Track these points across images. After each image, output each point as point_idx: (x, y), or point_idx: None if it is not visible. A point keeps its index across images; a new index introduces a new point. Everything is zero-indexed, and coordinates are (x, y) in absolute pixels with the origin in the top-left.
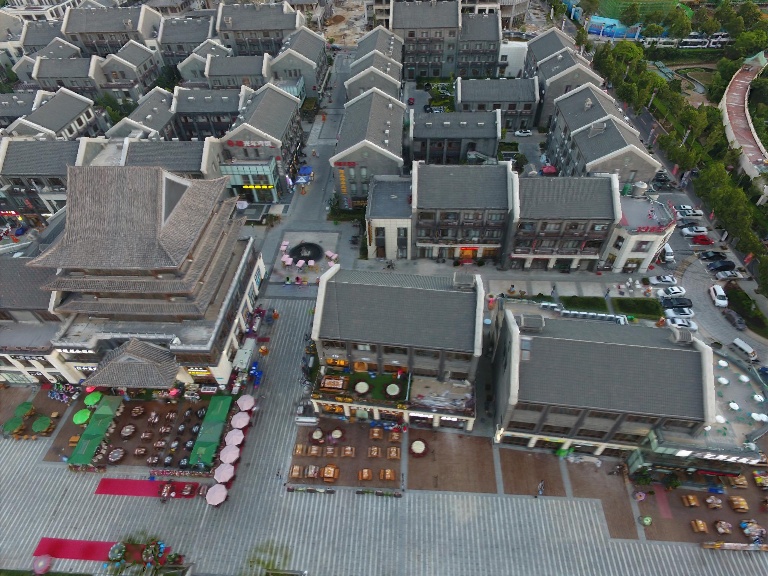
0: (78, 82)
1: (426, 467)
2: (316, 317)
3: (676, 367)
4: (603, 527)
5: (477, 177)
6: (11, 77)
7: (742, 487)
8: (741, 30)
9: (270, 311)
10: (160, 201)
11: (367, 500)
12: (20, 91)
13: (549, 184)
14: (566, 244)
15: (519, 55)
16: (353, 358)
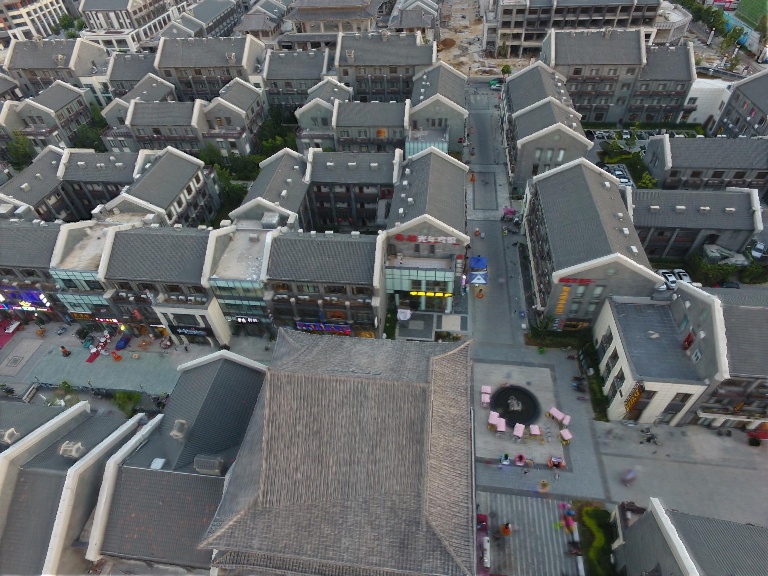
0: (178, 131)
1: None
2: None
3: None
4: None
5: None
6: (96, 118)
7: None
8: None
9: (493, 518)
10: (427, 442)
11: None
12: (109, 139)
13: None
14: None
15: (713, 98)
16: None
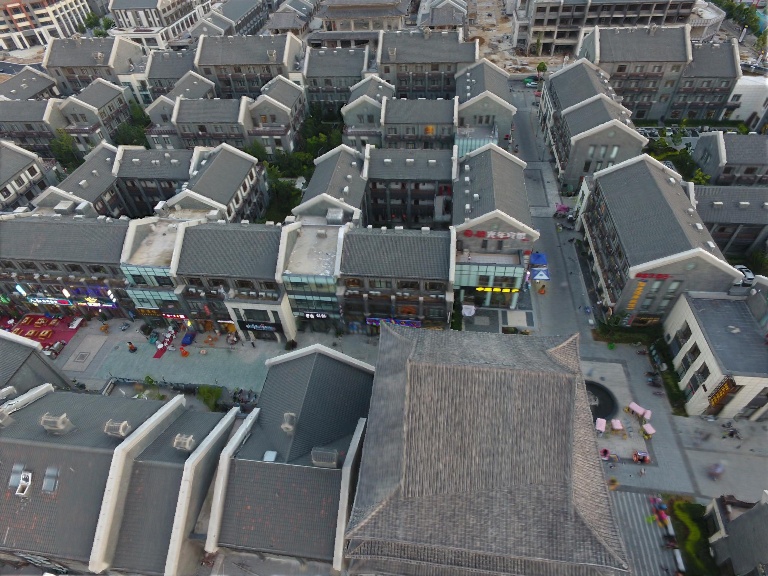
0: (223, 128)
1: None
2: None
3: None
4: None
5: None
6: (136, 116)
7: None
8: None
9: None
10: (573, 433)
11: None
12: (153, 136)
13: None
14: None
15: (758, 95)
16: None
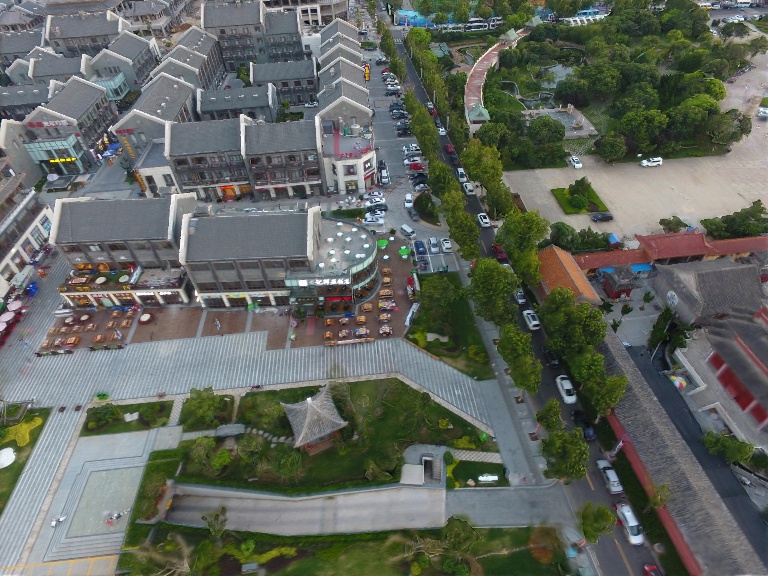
0: None
1: (148, 329)
2: (52, 228)
3: (292, 225)
4: (263, 345)
5: (218, 128)
6: None
7: (368, 310)
8: (508, 13)
9: None
10: None
11: (97, 354)
12: None
13: (269, 128)
14: (294, 174)
15: (319, 44)
16: (92, 259)
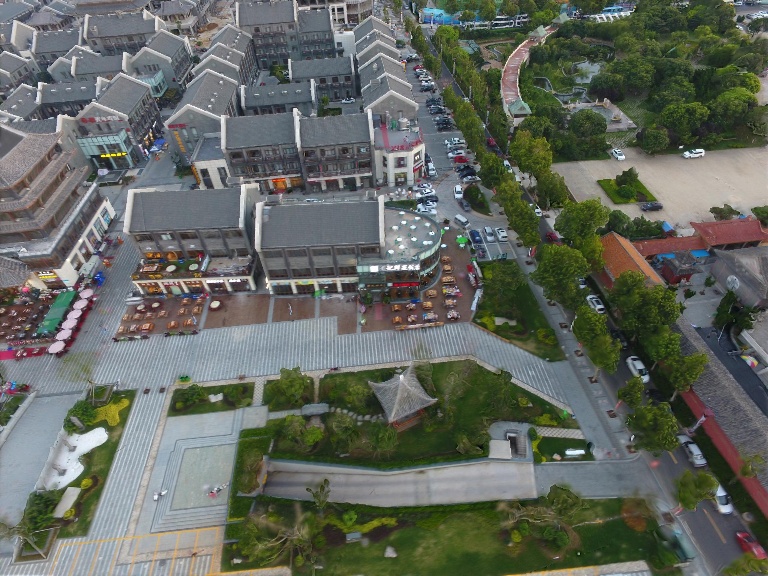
0: None
1: (219, 316)
2: (126, 217)
3: (363, 213)
4: (334, 330)
5: (272, 122)
6: None
7: (433, 296)
8: (534, 11)
9: (117, 240)
10: None
11: (172, 339)
12: None
13: (323, 121)
14: (346, 167)
15: (351, 41)
16: (162, 248)
